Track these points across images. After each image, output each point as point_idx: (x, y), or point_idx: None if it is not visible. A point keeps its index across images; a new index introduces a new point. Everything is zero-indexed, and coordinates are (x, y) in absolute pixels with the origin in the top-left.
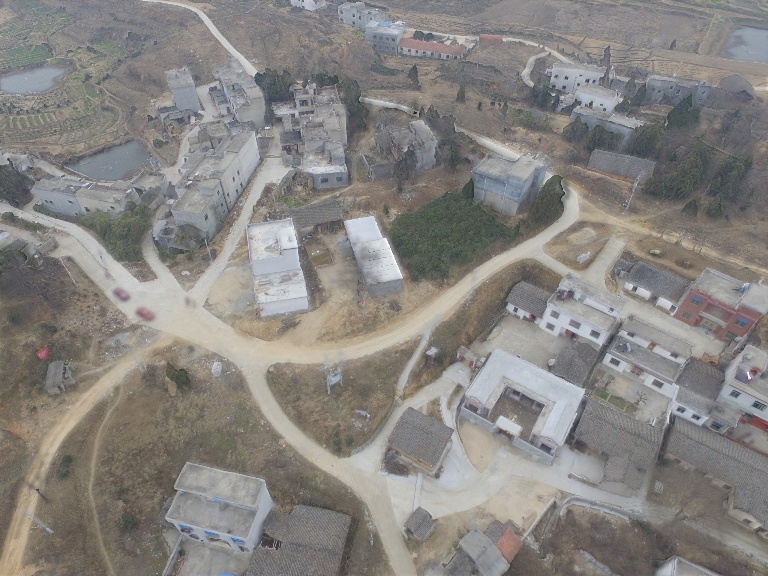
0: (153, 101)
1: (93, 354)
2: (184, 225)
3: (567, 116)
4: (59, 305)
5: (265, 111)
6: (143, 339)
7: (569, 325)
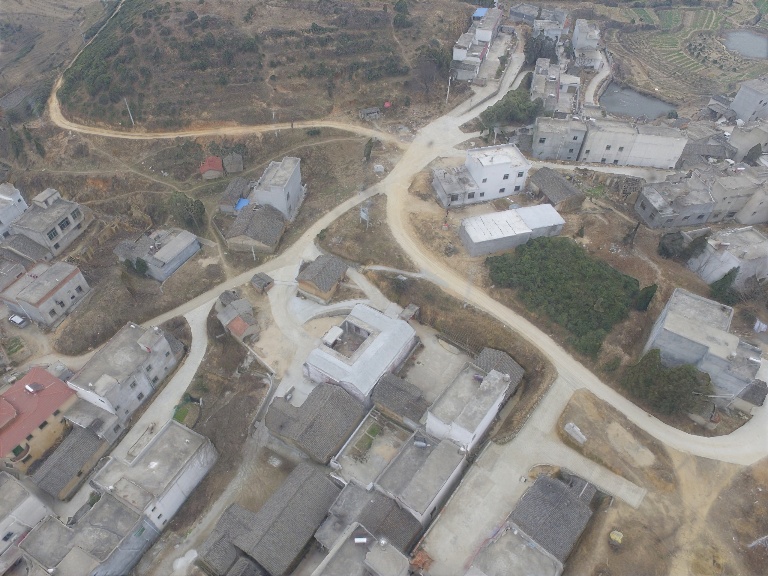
0: None
1: (390, 123)
2: (532, 135)
3: None
4: (428, 101)
5: None
6: (404, 137)
7: None
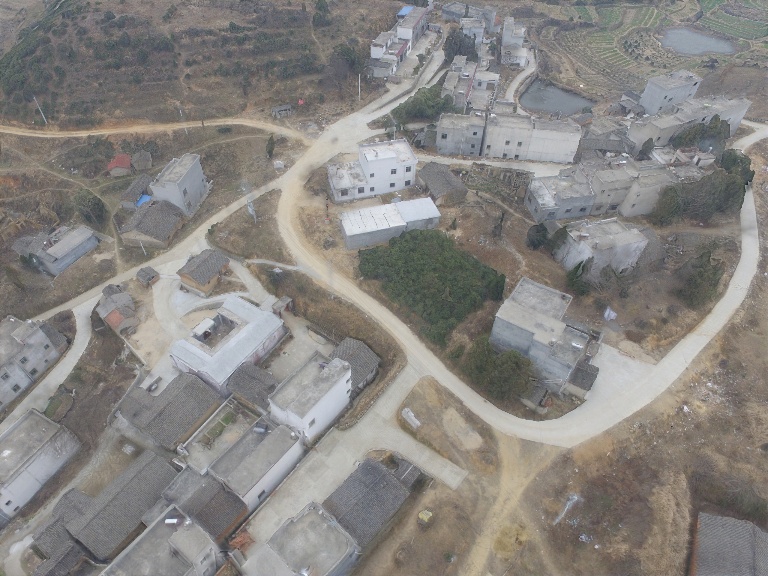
0: None
1: (301, 120)
2: None
3: None
4: (342, 98)
5: None
6: (311, 134)
7: None
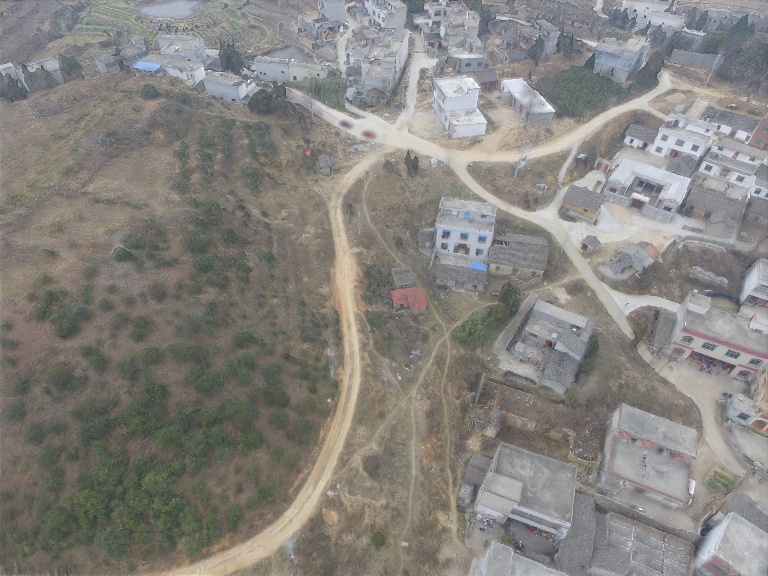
0: (300, 17)
1: (342, 155)
2: (372, 89)
3: (642, 35)
4: (305, 129)
5: (406, 20)
6: (374, 148)
7: (675, 145)
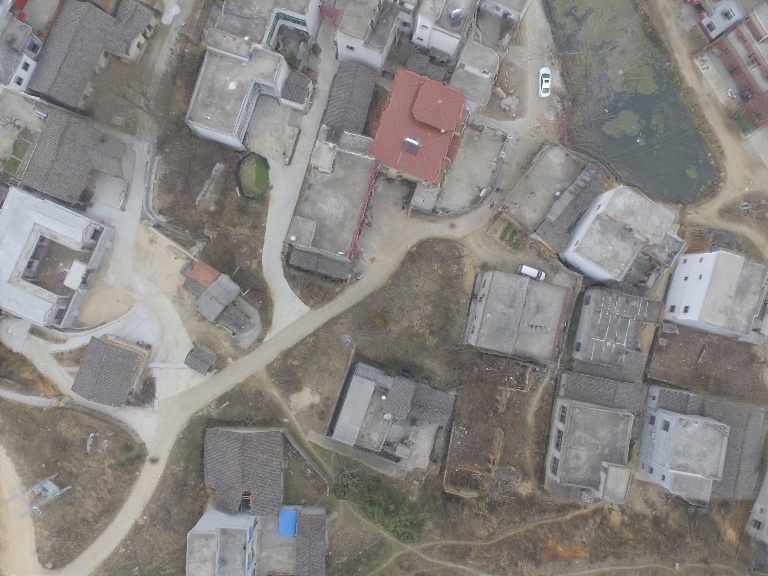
0: None
1: None
2: None
3: None
4: None
5: None
6: None
7: None
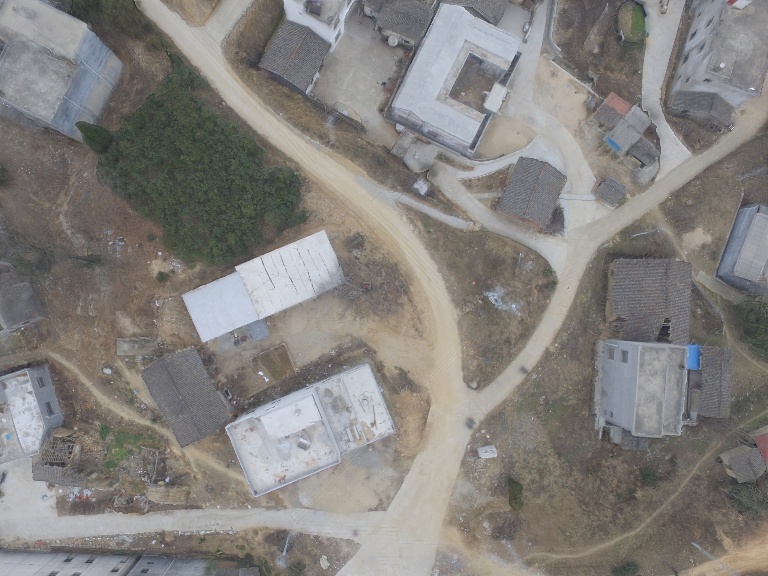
0: None
1: None
2: None
3: None
4: None
5: None
6: (454, 567)
7: (348, 7)
